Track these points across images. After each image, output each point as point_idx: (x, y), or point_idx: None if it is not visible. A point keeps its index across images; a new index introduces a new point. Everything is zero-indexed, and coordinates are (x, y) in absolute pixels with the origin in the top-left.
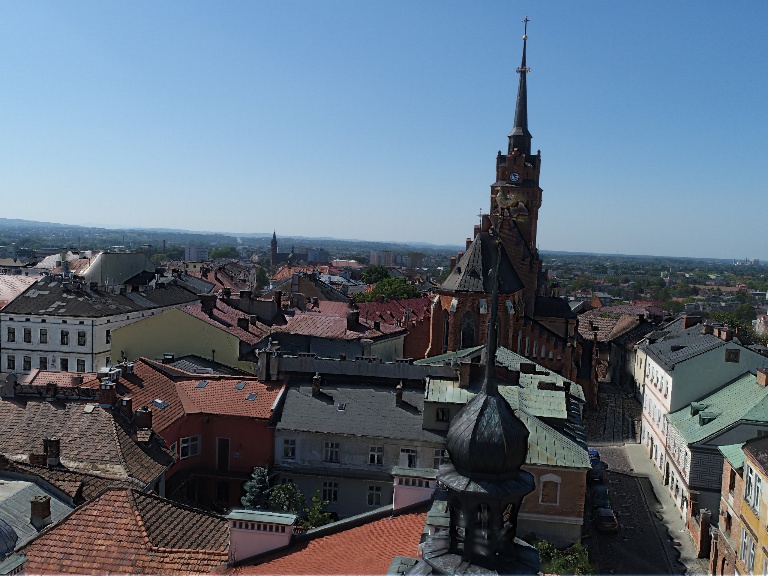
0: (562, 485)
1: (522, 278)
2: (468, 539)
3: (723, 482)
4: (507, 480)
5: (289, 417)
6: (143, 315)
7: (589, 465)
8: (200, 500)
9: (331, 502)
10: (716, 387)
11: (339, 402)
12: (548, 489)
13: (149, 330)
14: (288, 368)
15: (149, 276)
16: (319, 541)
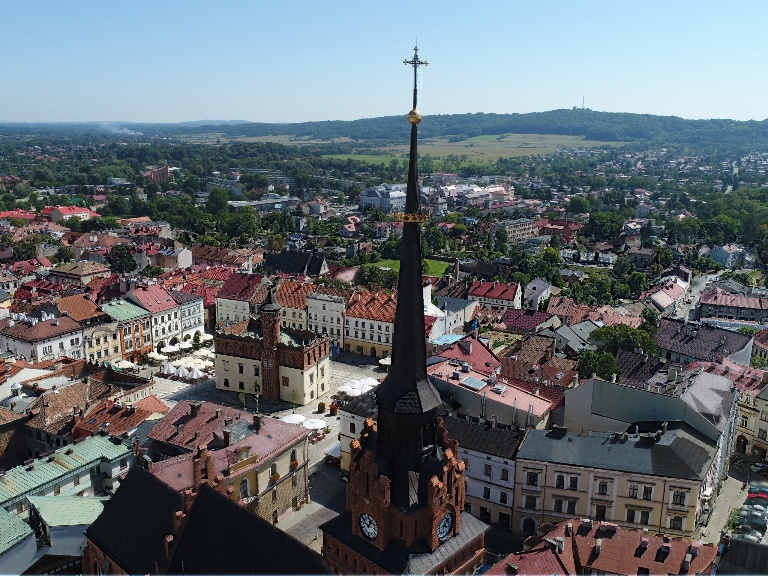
0: None
1: None
2: None
3: None
4: None
5: None
6: None
7: None
8: None
9: None
10: None
11: None
12: None
13: None
14: None
15: (661, 428)
16: None
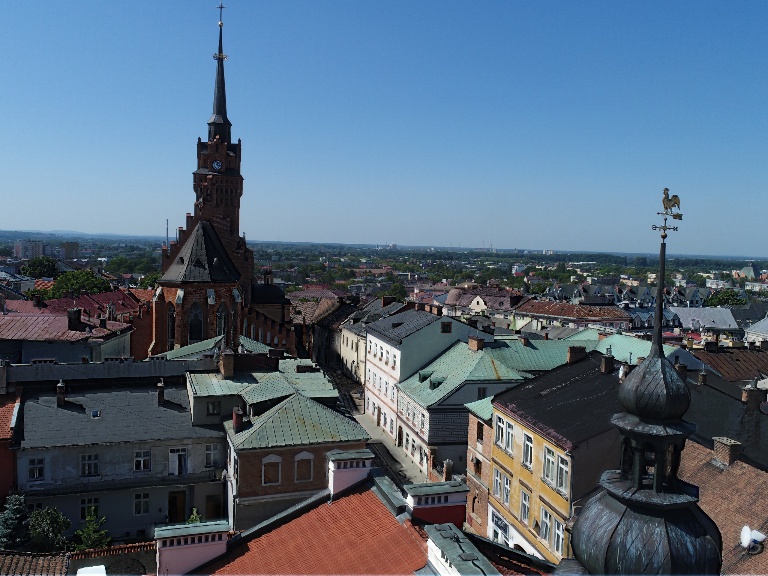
0: None
1: (238, 267)
2: (660, 474)
3: (470, 434)
4: (683, 423)
5: (34, 433)
6: None
7: (368, 436)
8: None
9: (91, 520)
10: (435, 356)
11: (91, 409)
12: None
13: None
14: (20, 378)
15: None
16: (259, 541)
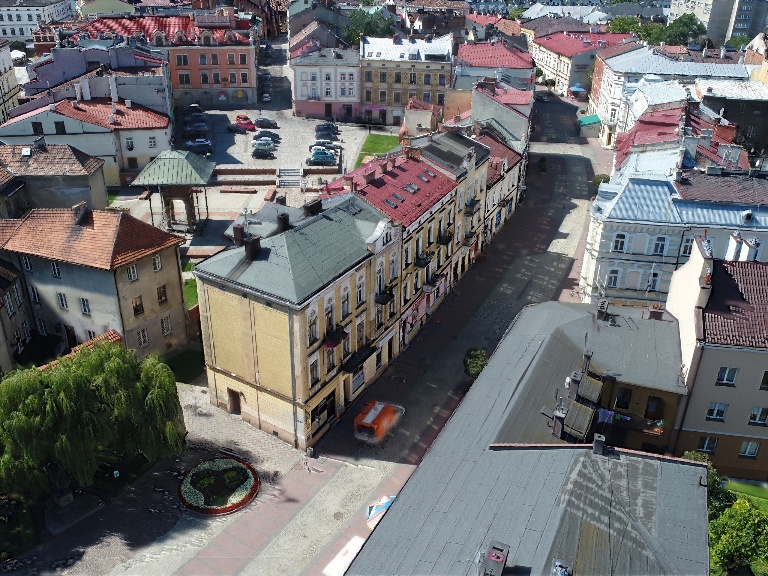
0: None
1: None
2: None
3: None
4: None
5: None
6: (54, 6)
7: None
8: None
9: None
10: None
11: None
12: None
13: (97, 5)
14: None
15: None
16: None
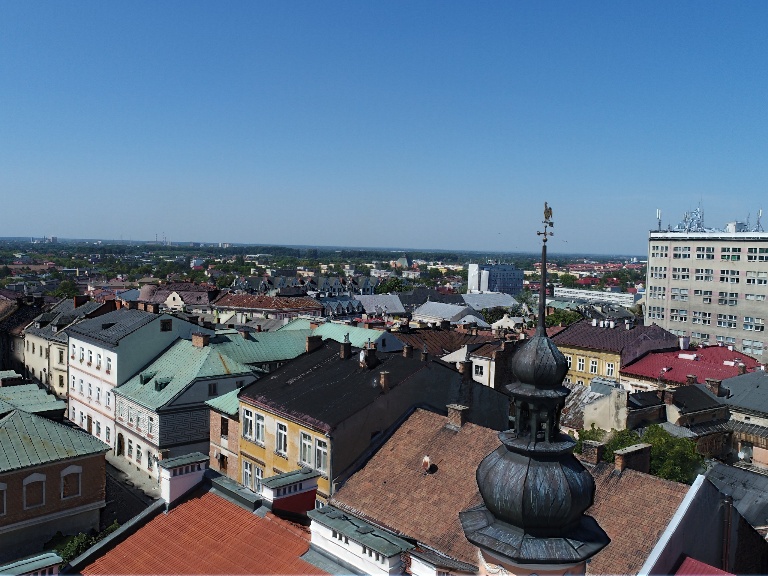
0: (83, 474)
1: None
2: None
3: (212, 431)
4: None
5: None
6: None
7: None
8: None
9: None
10: (155, 355)
11: None
12: (69, 482)
13: None
14: None
15: None
16: (94, 567)
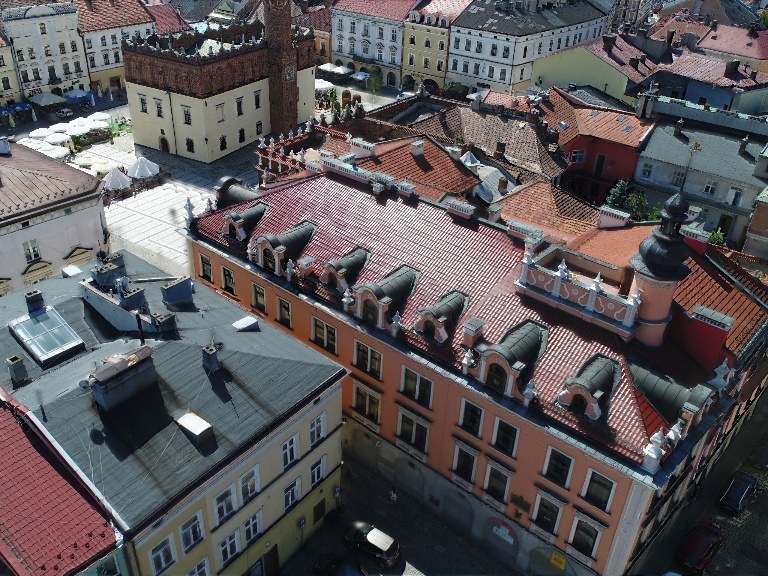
0: None
1: None
2: (664, 229)
3: None
4: (678, 217)
5: (652, 148)
6: (553, 33)
7: None
8: (579, 192)
9: None
10: None
11: None
12: None
13: (561, 62)
14: (660, 110)
15: None
16: (638, 227)
